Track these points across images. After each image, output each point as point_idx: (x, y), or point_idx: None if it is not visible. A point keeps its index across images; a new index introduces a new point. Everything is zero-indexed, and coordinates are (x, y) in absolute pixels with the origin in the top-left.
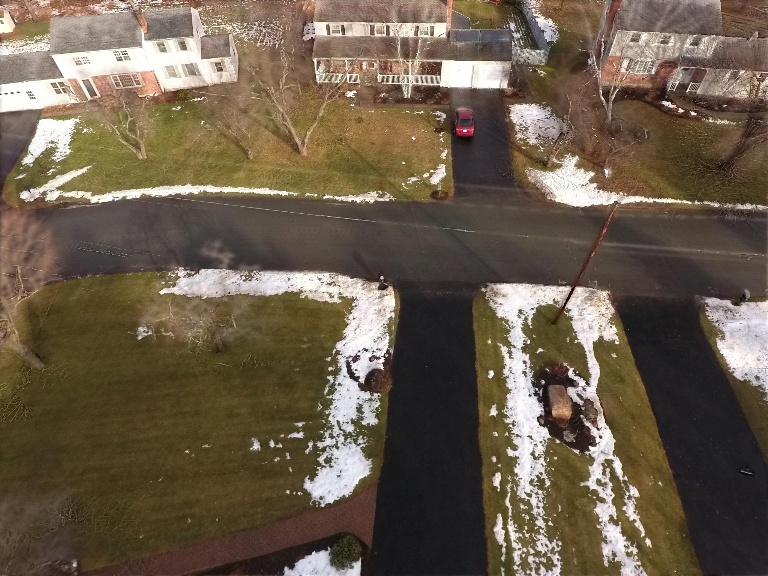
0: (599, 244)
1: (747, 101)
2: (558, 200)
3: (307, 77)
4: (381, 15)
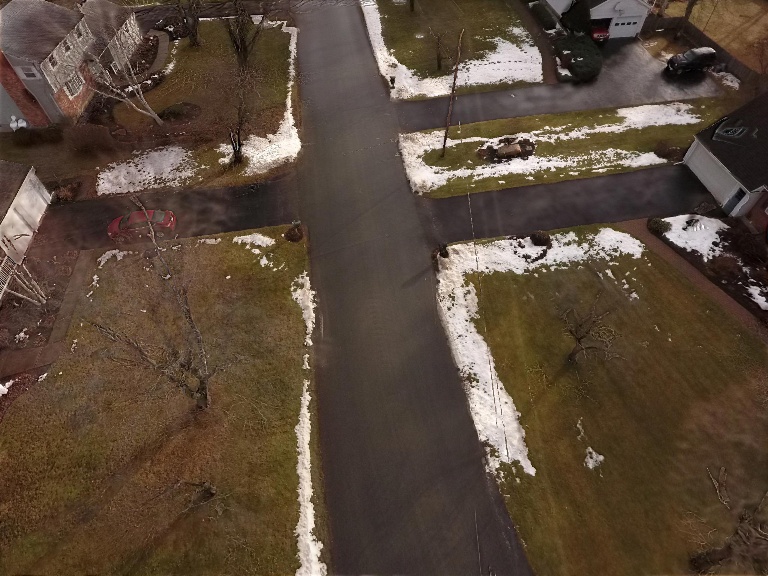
0: (350, 135)
1: (137, 51)
2: (294, 155)
3: None
4: None
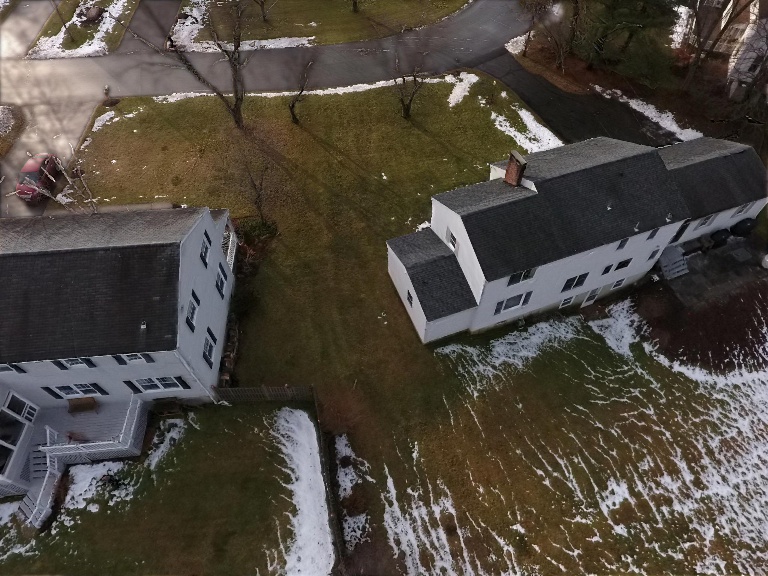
0: (1, 80)
1: None
2: (3, 106)
3: (265, 282)
4: (69, 221)
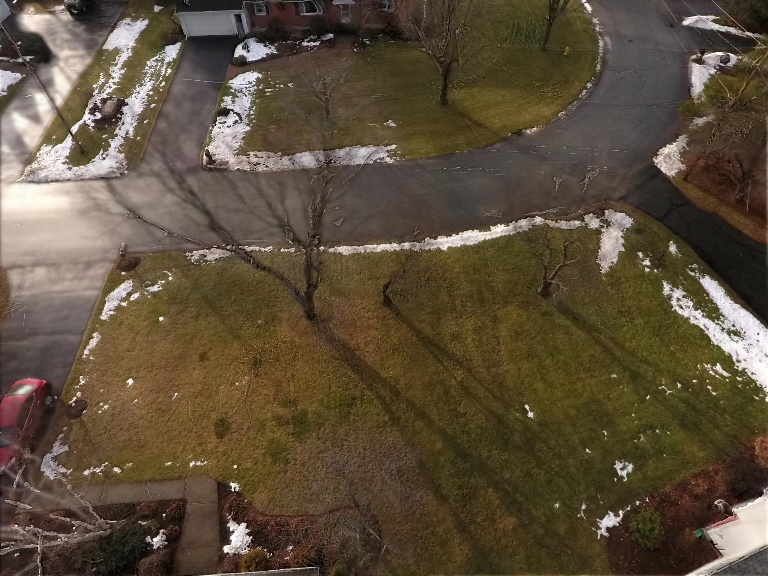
0: None
1: None
2: None
3: None
4: None
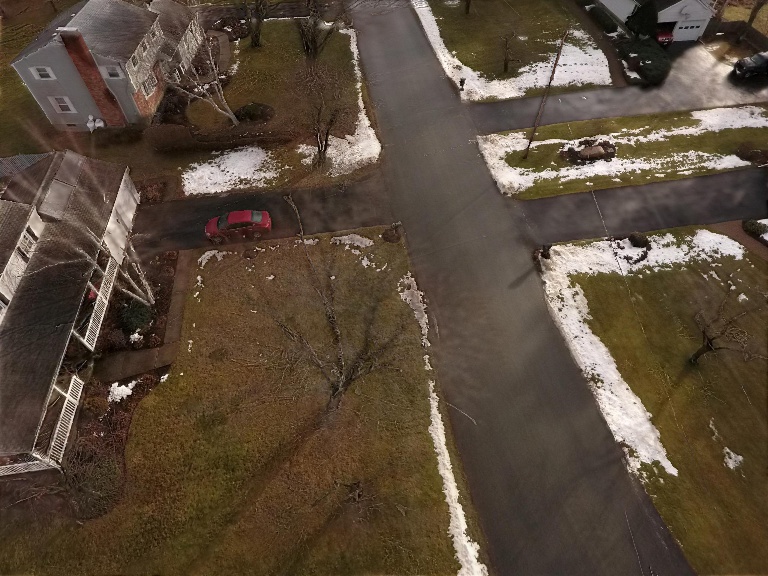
0: (428, 137)
1: (199, 52)
2: (377, 156)
3: None
4: None
